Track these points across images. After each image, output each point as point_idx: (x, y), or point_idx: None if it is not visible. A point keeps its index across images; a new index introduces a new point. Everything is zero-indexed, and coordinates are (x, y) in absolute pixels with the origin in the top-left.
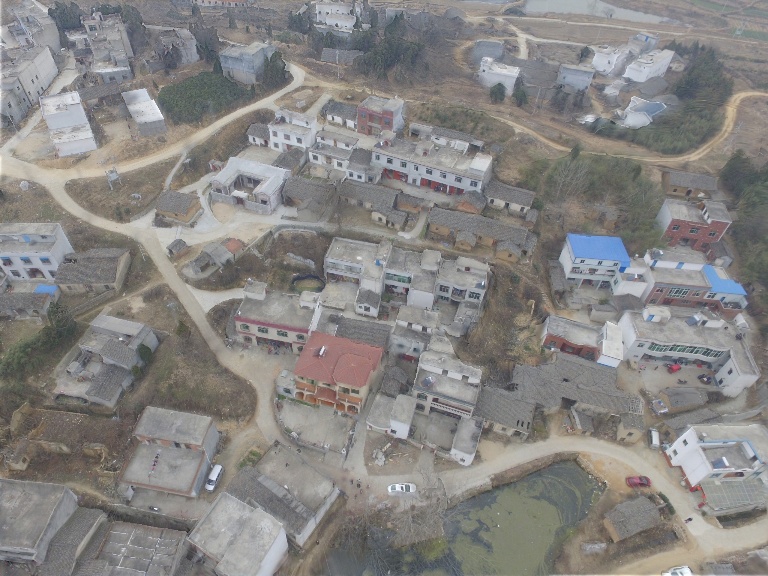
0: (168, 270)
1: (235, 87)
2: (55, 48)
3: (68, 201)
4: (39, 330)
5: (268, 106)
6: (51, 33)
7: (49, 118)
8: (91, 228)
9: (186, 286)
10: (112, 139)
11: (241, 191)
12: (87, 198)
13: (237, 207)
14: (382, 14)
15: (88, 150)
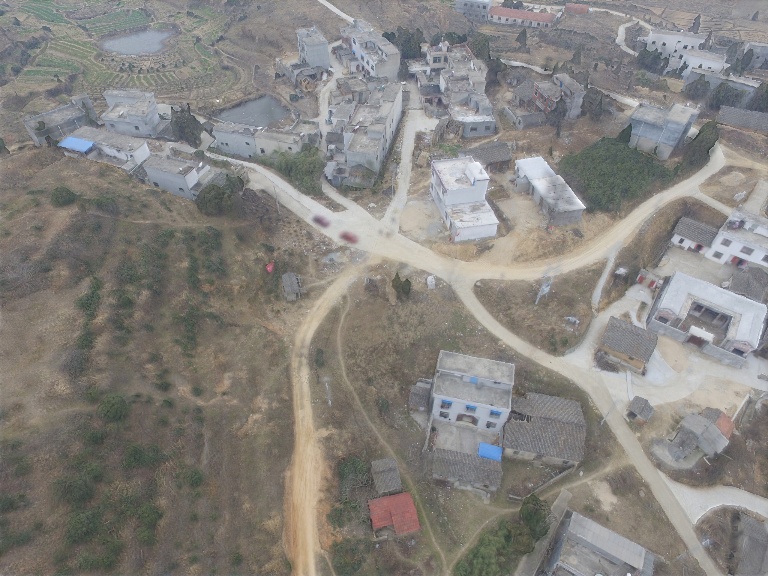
0: (631, 443)
1: (653, 164)
2: (390, 79)
3: (480, 310)
4: (490, 514)
5: (693, 193)
6: (393, 63)
7: (452, 193)
8: (519, 358)
9: (659, 473)
10: (515, 225)
11: (701, 328)
12: (507, 311)
13: (687, 347)
14: (738, 49)
15: (486, 236)
